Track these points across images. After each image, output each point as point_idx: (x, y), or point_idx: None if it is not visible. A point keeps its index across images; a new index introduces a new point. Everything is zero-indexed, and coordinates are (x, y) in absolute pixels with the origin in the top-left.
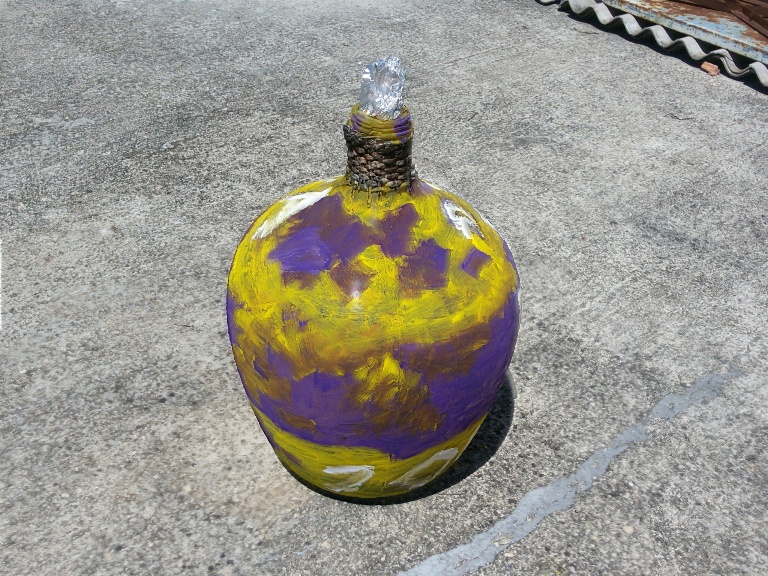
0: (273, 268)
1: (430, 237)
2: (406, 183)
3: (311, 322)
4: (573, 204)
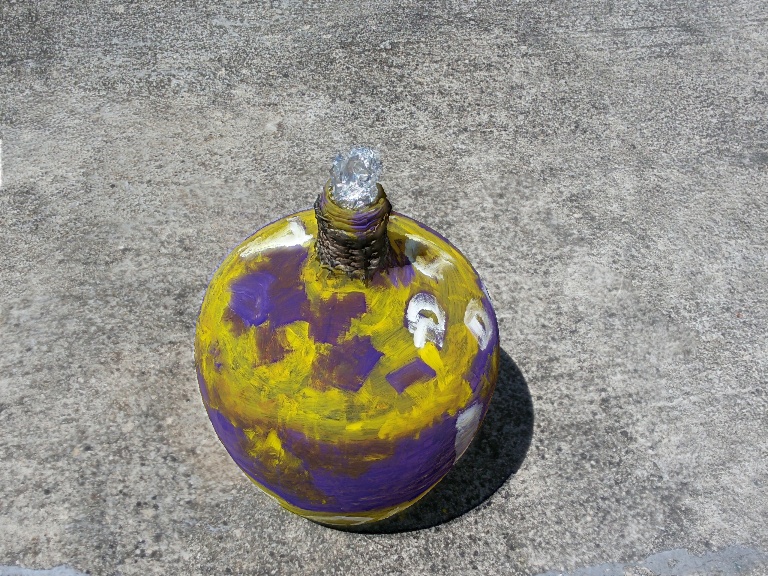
0: (223, 296)
1: (365, 333)
2: (360, 271)
3: (223, 367)
4: (762, 267)
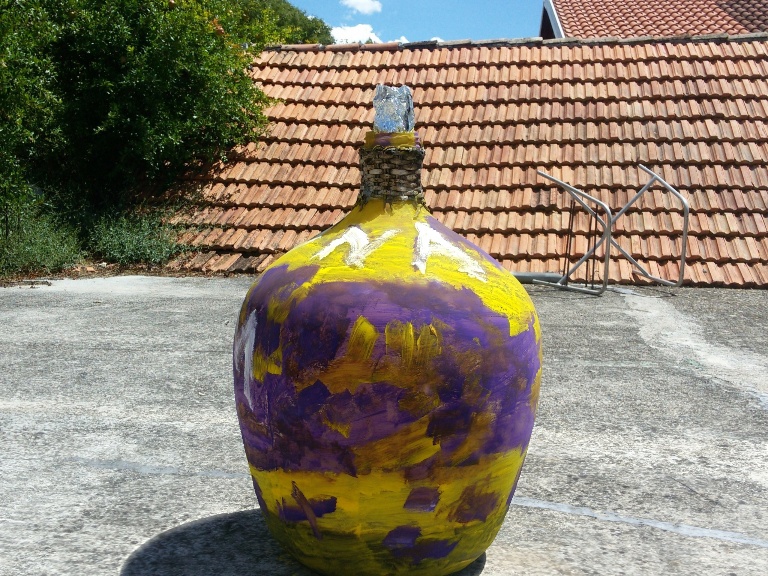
0: None
1: None
2: None
3: None
4: None
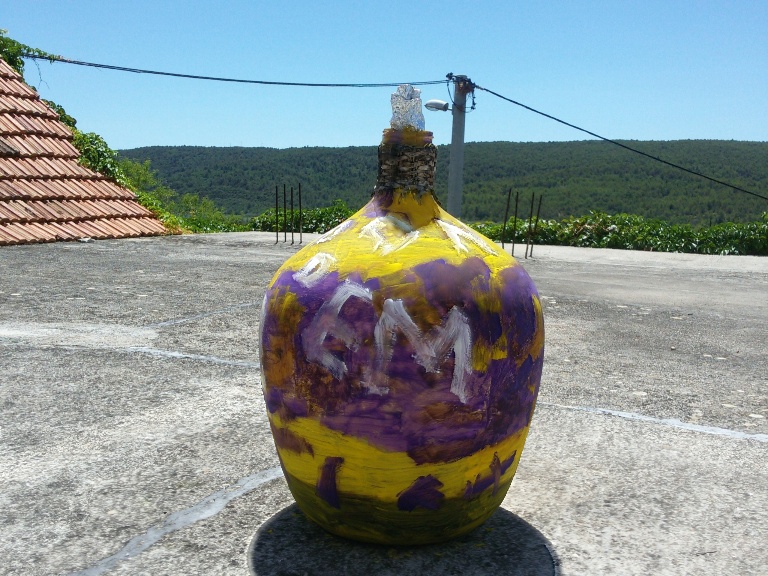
0: None
1: None
2: None
3: None
4: None
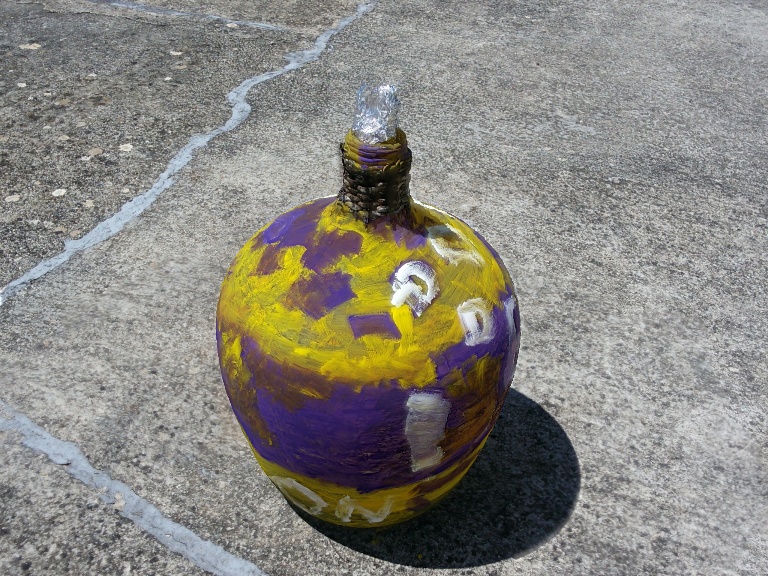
0: None
1: (349, 272)
2: (364, 212)
3: (232, 275)
4: None
